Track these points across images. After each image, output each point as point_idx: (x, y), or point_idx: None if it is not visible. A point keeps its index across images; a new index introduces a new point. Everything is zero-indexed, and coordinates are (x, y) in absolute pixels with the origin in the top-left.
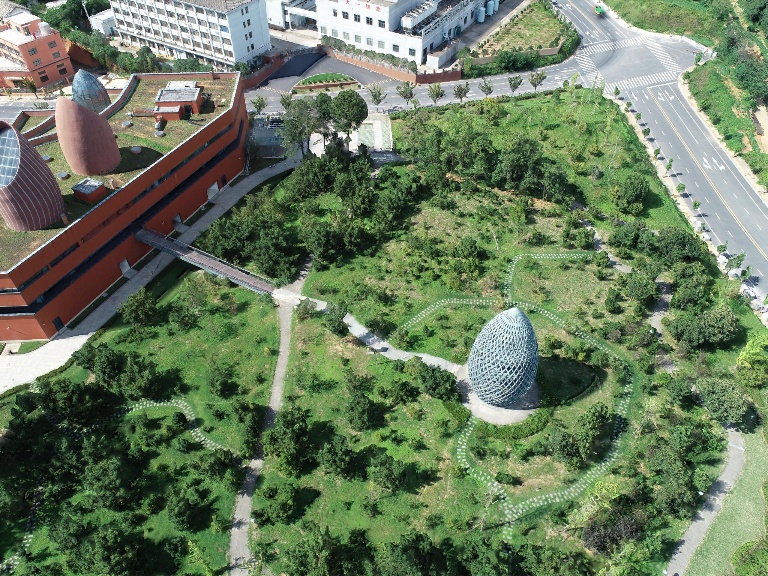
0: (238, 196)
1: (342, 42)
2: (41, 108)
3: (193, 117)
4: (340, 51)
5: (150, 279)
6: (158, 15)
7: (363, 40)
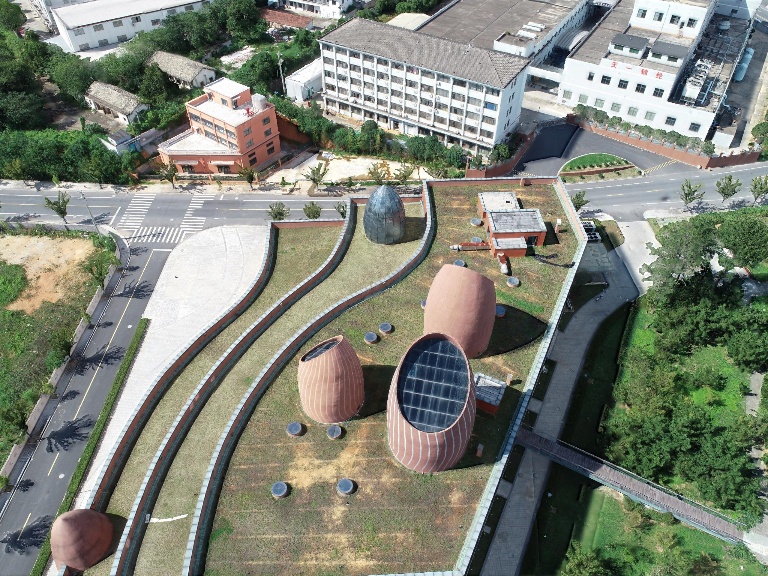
0: (579, 348)
1: (604, 113)
2: (278, 211)
3: (538, 251)
4: (600, 124)
5: (536, 499)
6: (391, 83)
7: (623, 109)
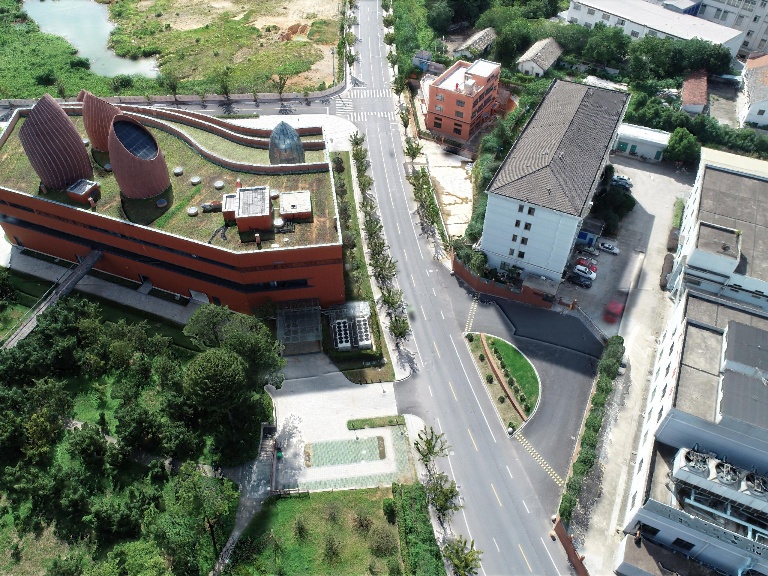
0: None
1: (612, 368)
2: (355, 138)
3: (232, 228)
4: None
5: None
6: None
7: None
